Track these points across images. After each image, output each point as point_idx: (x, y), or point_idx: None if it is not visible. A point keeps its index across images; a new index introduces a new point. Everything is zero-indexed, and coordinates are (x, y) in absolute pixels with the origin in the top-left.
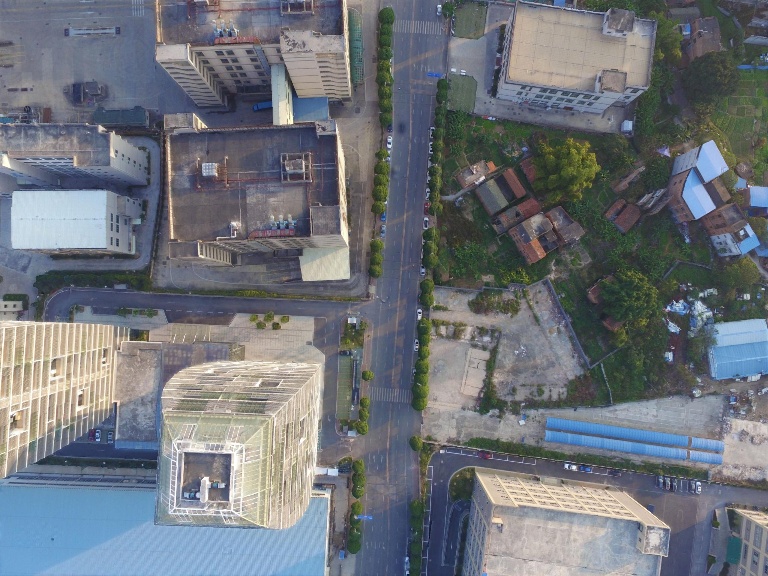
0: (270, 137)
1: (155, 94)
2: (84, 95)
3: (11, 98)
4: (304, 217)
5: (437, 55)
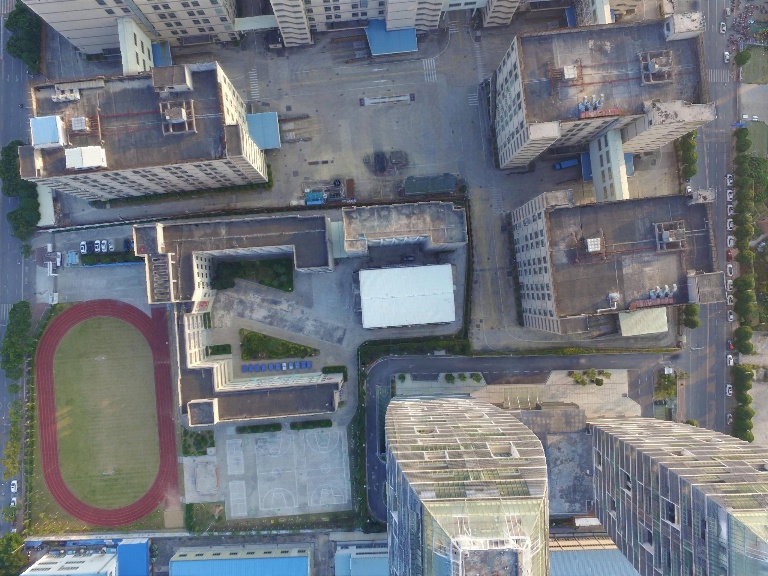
0: (640, 207)
1: (455, 159)
2: (386, 164)
3: (313, 172)
4: (679, 284)
5: (727, 102)
